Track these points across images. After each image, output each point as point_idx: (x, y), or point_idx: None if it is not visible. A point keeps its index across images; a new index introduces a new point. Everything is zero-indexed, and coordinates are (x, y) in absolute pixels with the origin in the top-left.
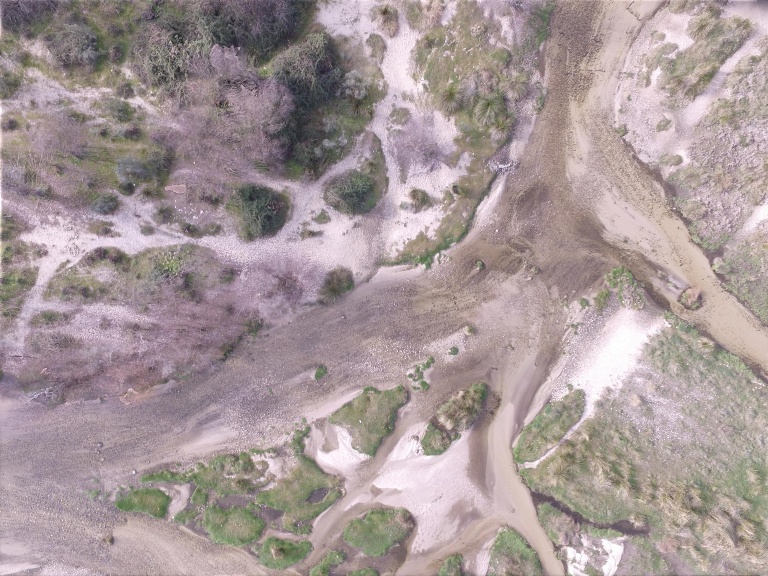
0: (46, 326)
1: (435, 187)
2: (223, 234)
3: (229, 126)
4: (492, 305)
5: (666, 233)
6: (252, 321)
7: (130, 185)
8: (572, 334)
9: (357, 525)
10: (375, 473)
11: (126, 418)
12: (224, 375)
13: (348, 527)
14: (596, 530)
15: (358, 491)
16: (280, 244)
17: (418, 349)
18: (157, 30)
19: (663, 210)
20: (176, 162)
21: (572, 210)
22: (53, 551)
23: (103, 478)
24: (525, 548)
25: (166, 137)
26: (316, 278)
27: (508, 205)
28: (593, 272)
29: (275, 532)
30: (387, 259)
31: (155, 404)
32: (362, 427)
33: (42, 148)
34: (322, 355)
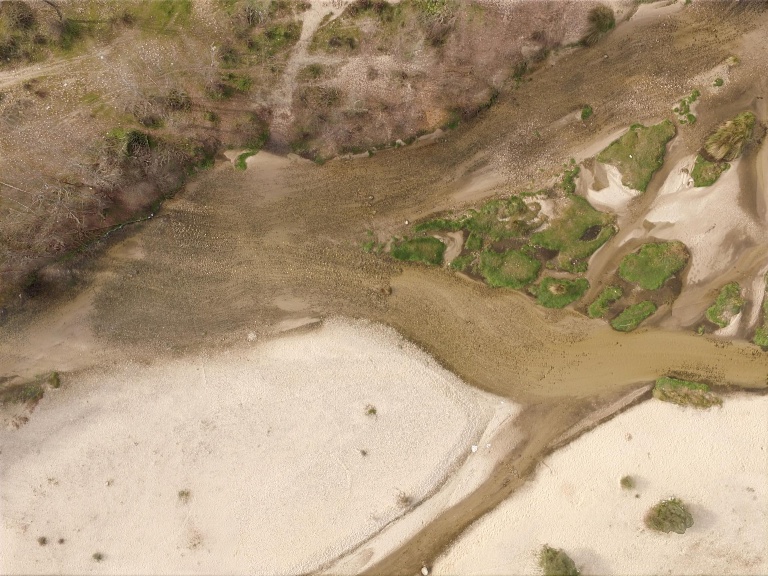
0: (313, 80)
1: None
2: None
3: None
4: (754, 35)
5: None
6: (518, 63)
7: None
8: None
9: (633, 259)
10: (647, 208)
11: (395, 170)
12: (489, 122)
13: (624, 261)
14: None
15: (631, 227)
16: None
17: (682, 83)
18: None
19: None
20: None
21: None
22: (332, 305)
23: (376, 230)
24: None
25: None
26: (579, 17)
27: None
28: None
29: (551, 272)
30: None
31: (423, 155)
32: (633, 162)
33: None
34: (586, 96)
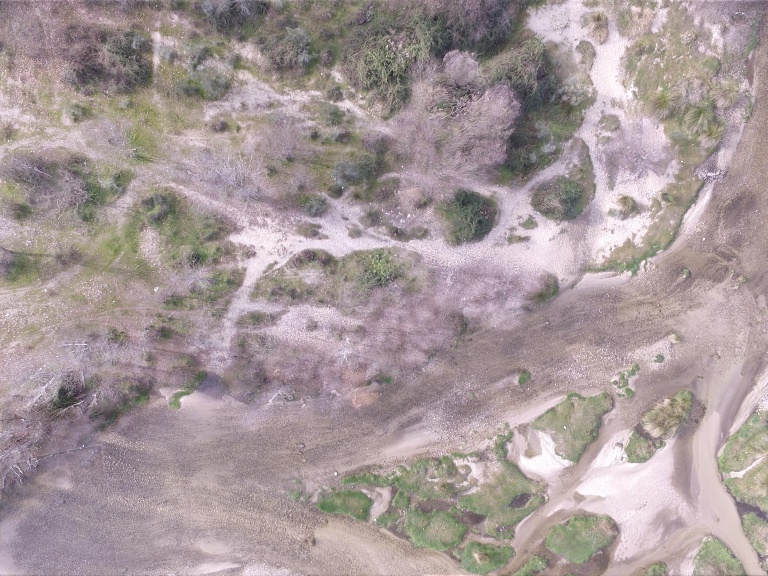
0: (253, 327)
1: (642, 194)
2: (430, 238)
3: (470, 131)
4: (698, 313)
5: None
6: (458, 325)
7: (340, 188)
8: None
9: (560, 531)
10: (578, 479)
11: (328, 420)
12: (426, 379)
13: (551, 533)
14: None
15: (561, 497)
16: (486, 249)
17: (623, 356)
18: (372, 34)
19: None
20: (384, 166)
21: None
22: (254, 551)
23: (305, 479)
24: (730, 558)
25: (379, 141)
26: (522, 283)
27: (715, 213)
28: None
29: (477, 536)
30: (593, 265)
31: None
32: (567, 433)
33: (252, 150)
34: (525, 360)
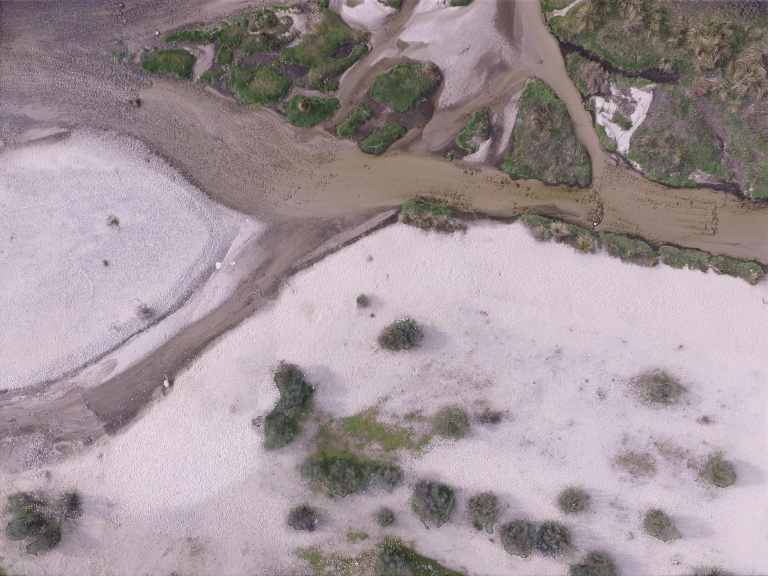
0: None
1: None
2: None
3: None
4: None
5: None
6: None
7: None
8: None
9: (384, 79)
10: (401, 27)
11: None
12: None
13: (375, 81)
14: (625, 79)
15: (384, 46)
16: None
17: None
18: None
19: None
20: None
21: None
22: (80, 115)
23: (126, 40)
24: (553, 98)
25: None
26: None
27: None
28: None
29: (301, 90)
30: None
31: None
32: None
33: None
34: None
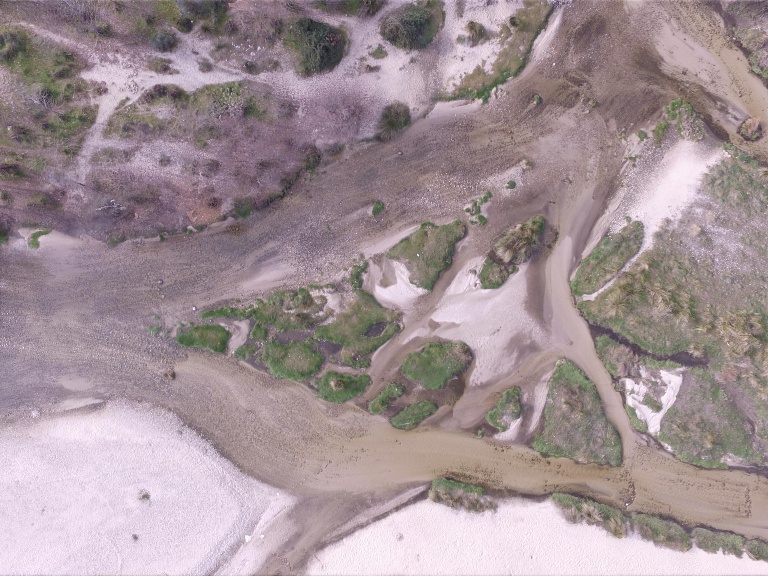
0: (106, 163)
1: (492, 21)
2: (280, 70)
3: None
4: (549, 139)
5: (725, 64)
6: (310, 156)
7: (188, 21)
8: (630, 167)
9: (415, 358)
10: (433, 307)
11: (185, 256)
12: (282, 212)
13: (407, 360)
14: (654, 362)
15: (416, 325)
16: (337, 80)
17: (475, 184)
18: None
19: (722, 41)
20: None
21: (630, 42)
22: (116, 386)
23: (164, 315)
24: (583, 380)
25: None
26: (373, 113)
27: (565, 39)
28: (651, 104)
29: (334, 366)
30: (444, 94)
31: (214, 242)
32: (420, 261)
33: None
34: (379, 191)
